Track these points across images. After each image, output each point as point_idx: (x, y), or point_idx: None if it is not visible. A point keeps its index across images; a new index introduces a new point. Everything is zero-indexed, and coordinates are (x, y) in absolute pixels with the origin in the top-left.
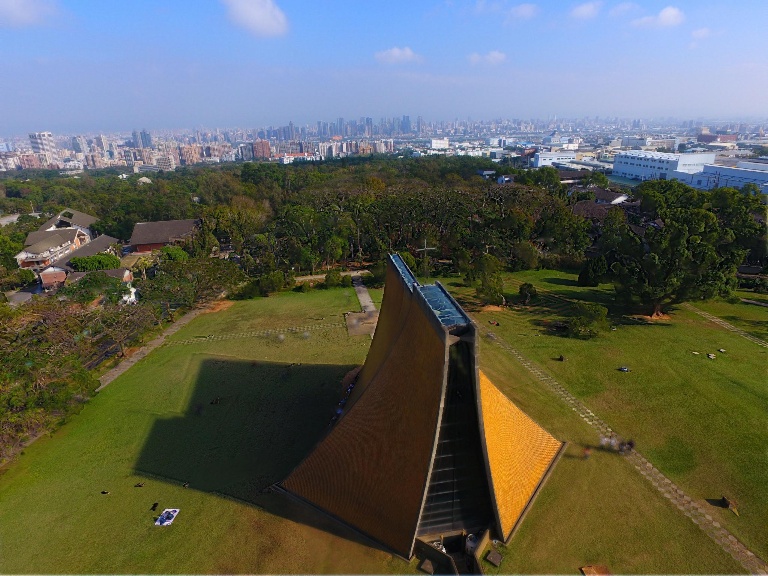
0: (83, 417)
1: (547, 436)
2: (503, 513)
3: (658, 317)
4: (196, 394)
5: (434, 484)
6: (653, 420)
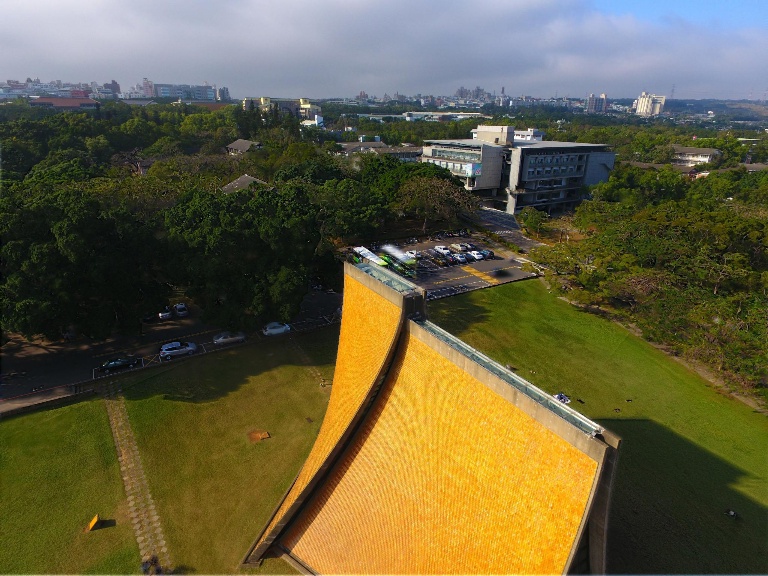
0: None
1: None
2: None
3: None
4: None
5: None
6: None
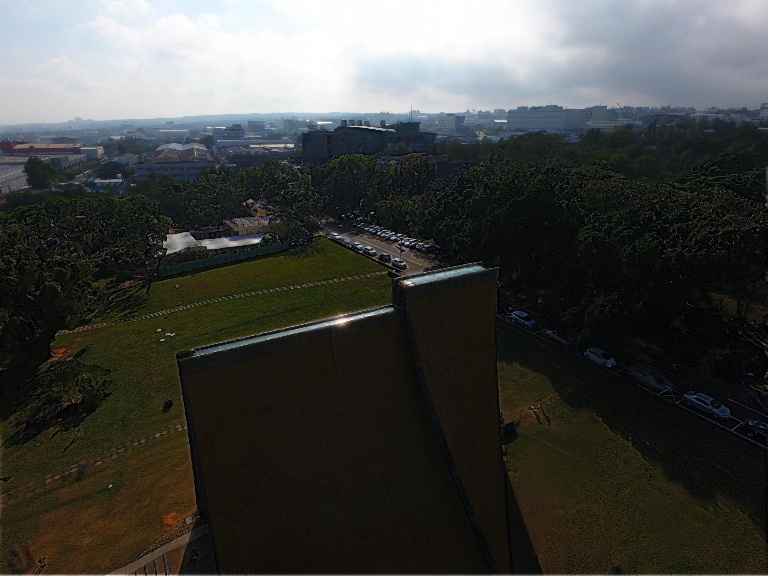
0: None
1: None
2: None
3: (58, 354)
4: None
5: None
6: None
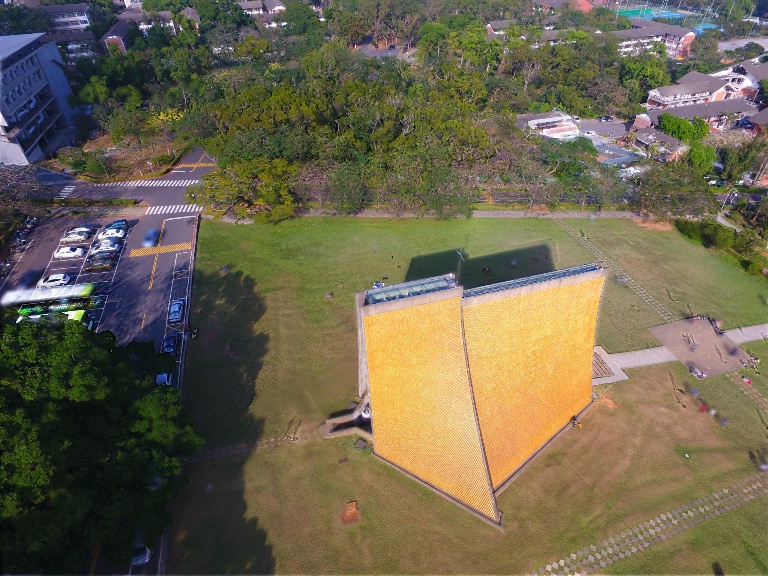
0: (453, 223)
1: (487, 495)
2: (380, 440)
3: None
4: (493, 258)
5: None
6: None
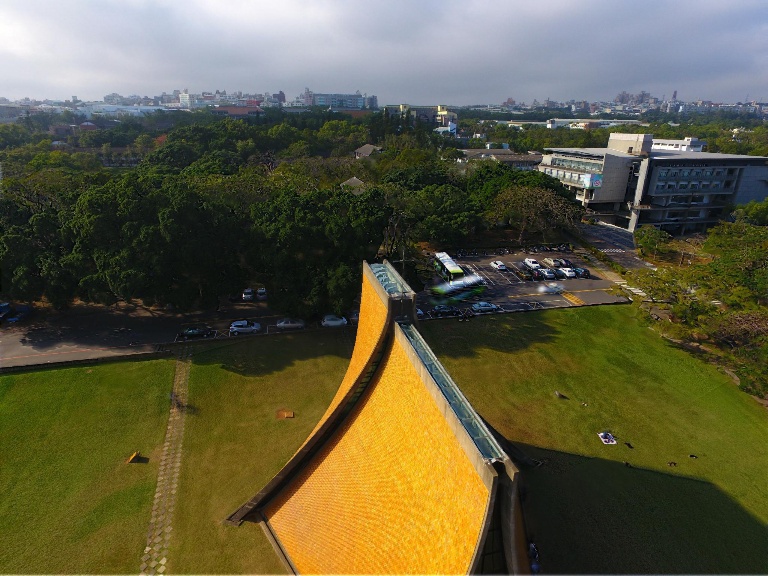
0: None
1: None
2: None
3: None
4: None
5: None
6: (62, 574)
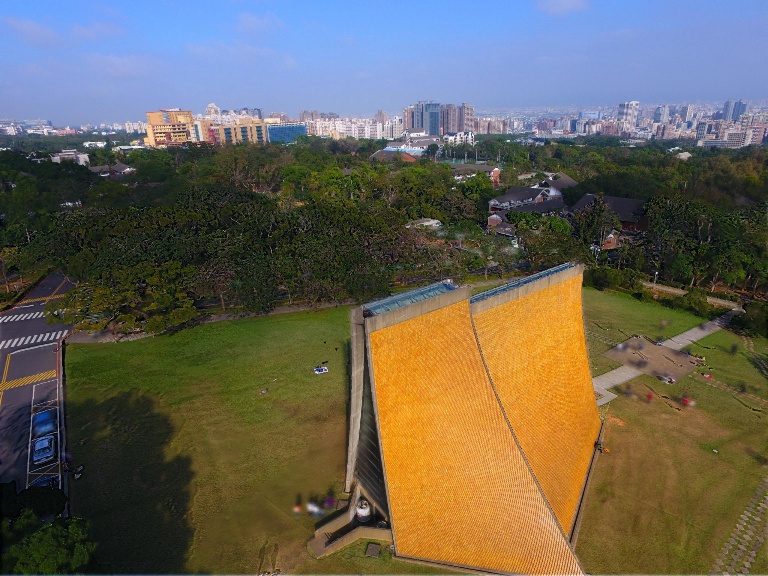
0: None
1: (566, 554)
2: (402, 528)
3: None
4: None
5: (367, 449)
6: None
